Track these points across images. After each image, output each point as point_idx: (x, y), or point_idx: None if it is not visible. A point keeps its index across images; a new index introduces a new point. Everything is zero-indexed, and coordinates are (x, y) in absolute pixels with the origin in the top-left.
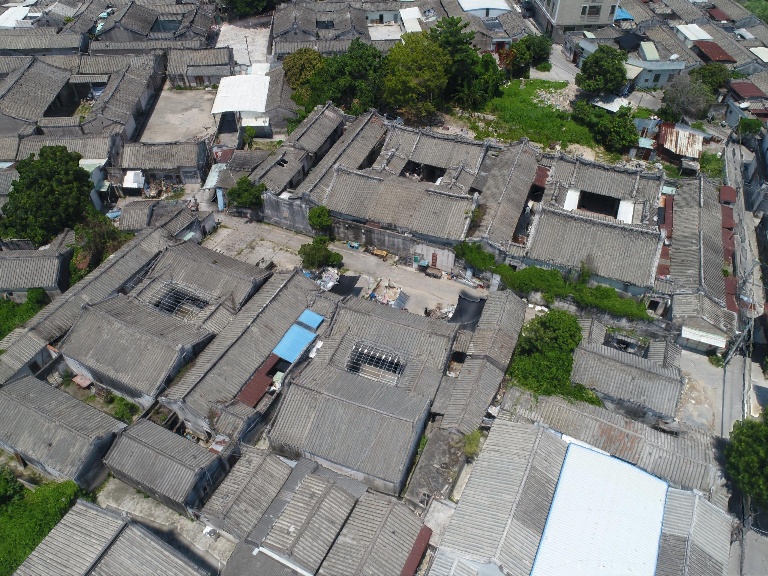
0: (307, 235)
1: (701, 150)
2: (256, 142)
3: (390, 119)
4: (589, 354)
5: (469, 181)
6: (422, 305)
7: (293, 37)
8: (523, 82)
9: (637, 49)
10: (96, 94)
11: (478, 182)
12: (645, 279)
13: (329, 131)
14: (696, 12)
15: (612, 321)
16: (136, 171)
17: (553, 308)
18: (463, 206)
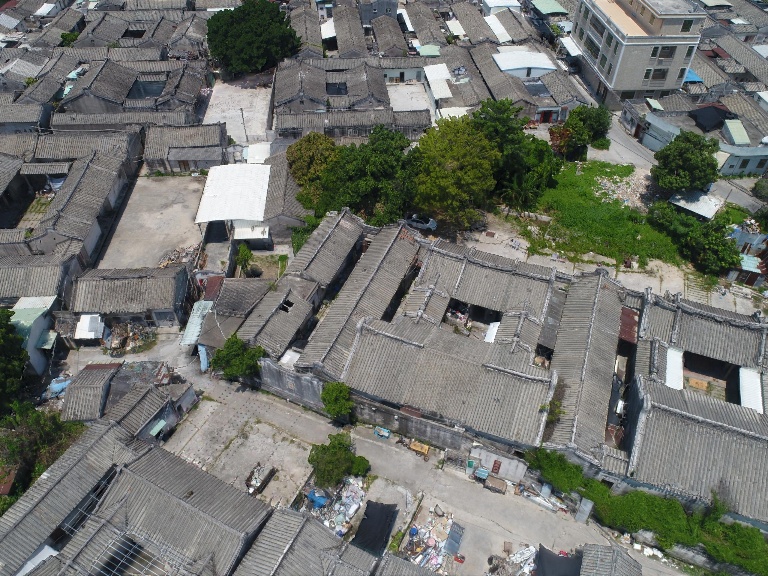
0: (319, 413)
1: None
2: (252, 256)
3: (420, 222)
4: None
5: (534, 335)
6: (483, 545)
7: (298, 106)
8: (579, 166)
9: (720, 128)
10: (54, 186)
11: (546, 334)
12: None
13: (346, 250)
14: None
15: None
16: (93, 315)
17: (669, 552)
18: (536, 392)
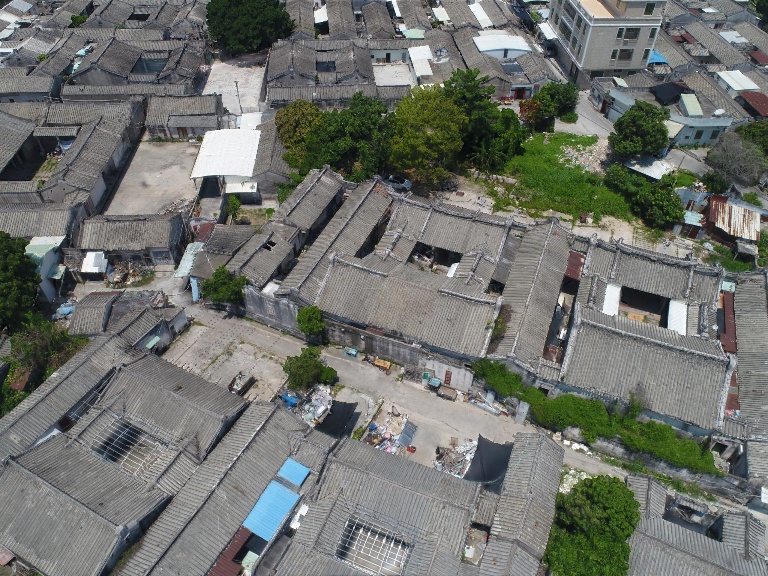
0: (296, 336)
1: (759, 230)
2: (242, 210)
3: (396, 182)
4: (650, 540)
5: (489, 272)
6: (433, 440)
7: (289, 81)
8: (547, 136)
9: (676, 102)
10: (64, 148)
11: (500, 272)
12: (711, 419)
13: (326, 202)
14: (738, 56)
15: (669, 470)
16: (98, 252)
17: (594, 447)
18: (483, 312)
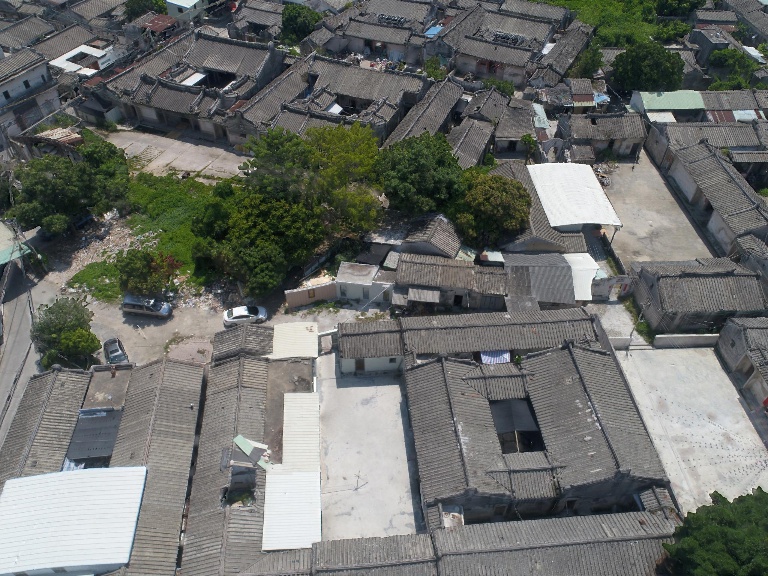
0: None
1: None
2: None
3: None
4: None
5: None
6: None
7: None
8: None
9: None
10: None
11: (299, 103)
12: None
13: None
14: None
15: None
16: None
17: None
18: None
